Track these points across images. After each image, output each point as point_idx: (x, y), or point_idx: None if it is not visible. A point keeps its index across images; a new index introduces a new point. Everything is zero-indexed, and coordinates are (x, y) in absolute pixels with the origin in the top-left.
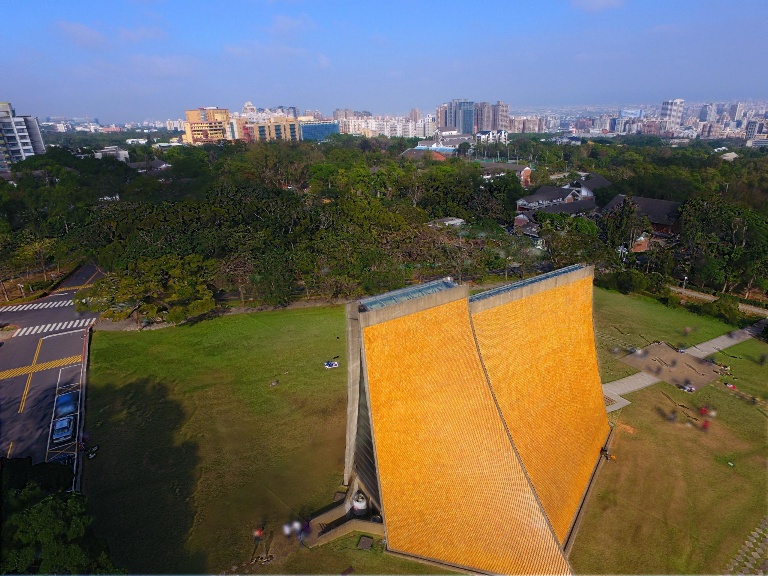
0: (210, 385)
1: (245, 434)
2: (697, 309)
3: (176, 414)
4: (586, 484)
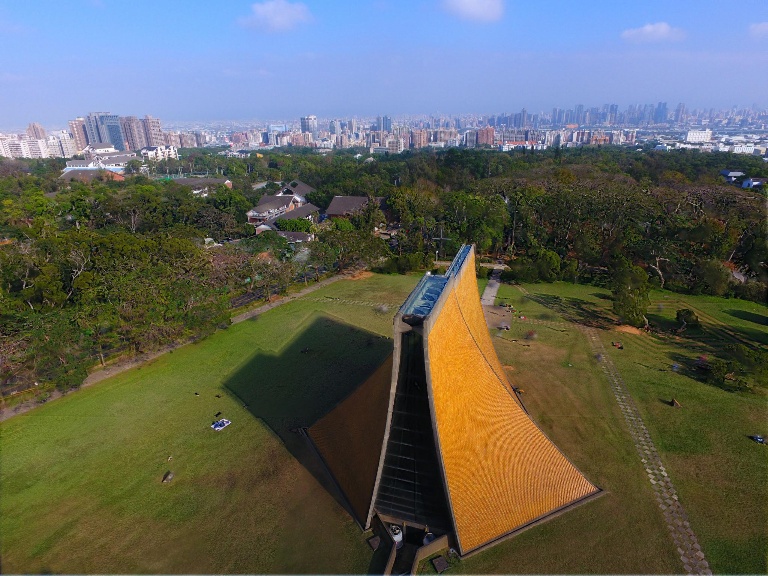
0: (69, 526)
1: (194, 552)
2: None
3: None
4: None
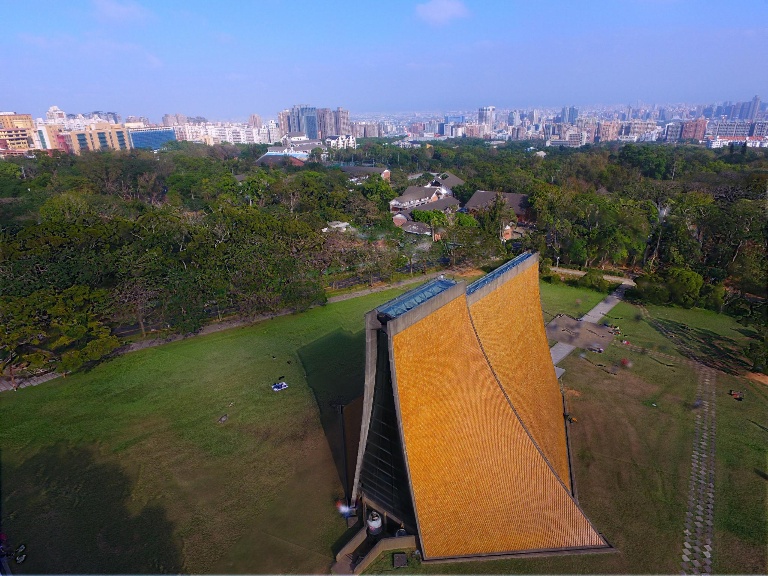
0: (145, 436)
1: (214, 482)
2: (574, 283)
3: (116, 479)
4: (566, 448)
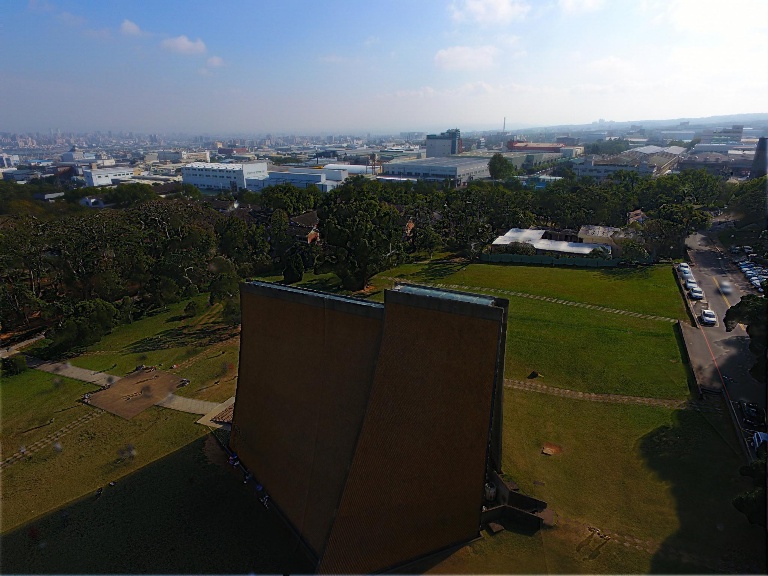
0: None
1: None
2: None
3: None
4: None
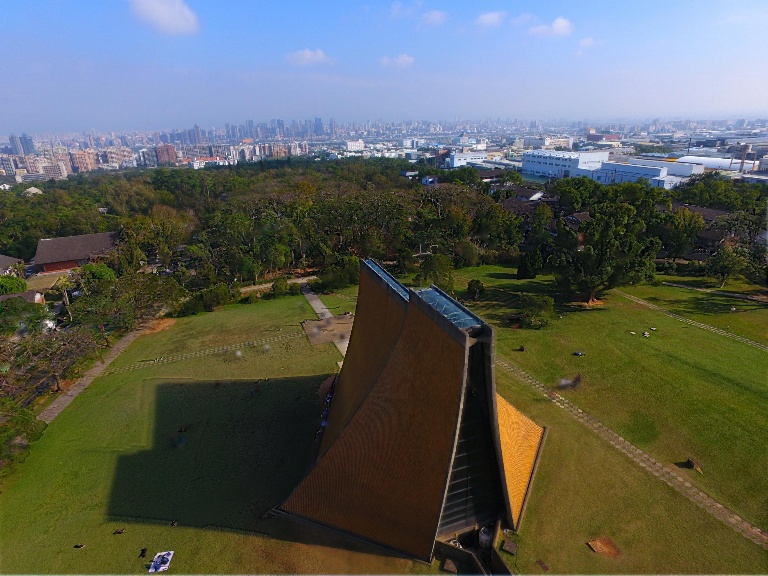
0: None
1: None
2: (269, 296)
3: None
4: None
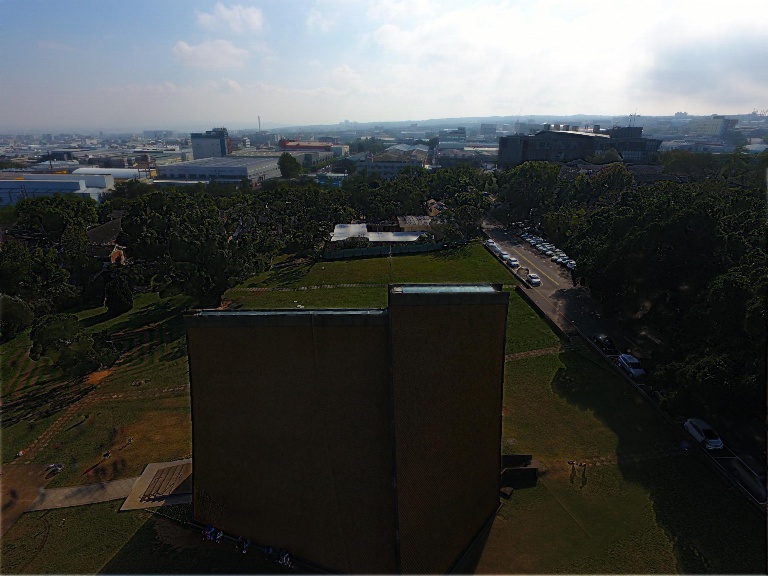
0: None
1: None
2: None
3: None
4: None
